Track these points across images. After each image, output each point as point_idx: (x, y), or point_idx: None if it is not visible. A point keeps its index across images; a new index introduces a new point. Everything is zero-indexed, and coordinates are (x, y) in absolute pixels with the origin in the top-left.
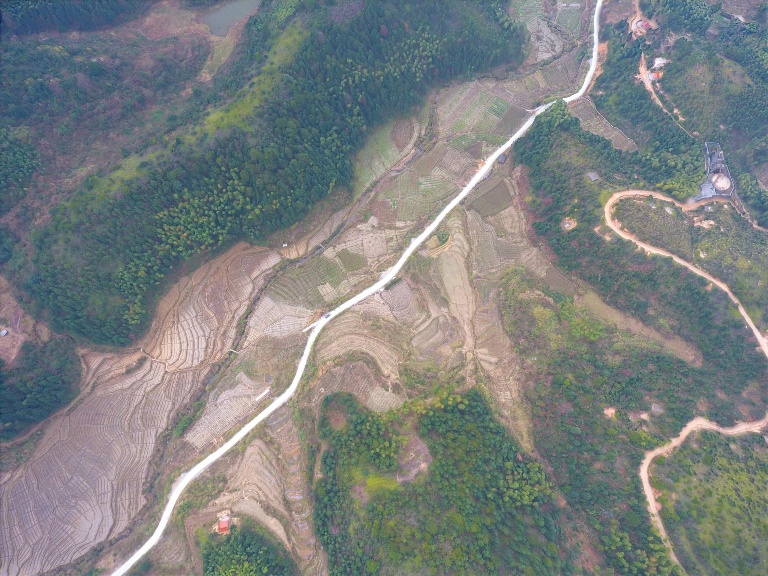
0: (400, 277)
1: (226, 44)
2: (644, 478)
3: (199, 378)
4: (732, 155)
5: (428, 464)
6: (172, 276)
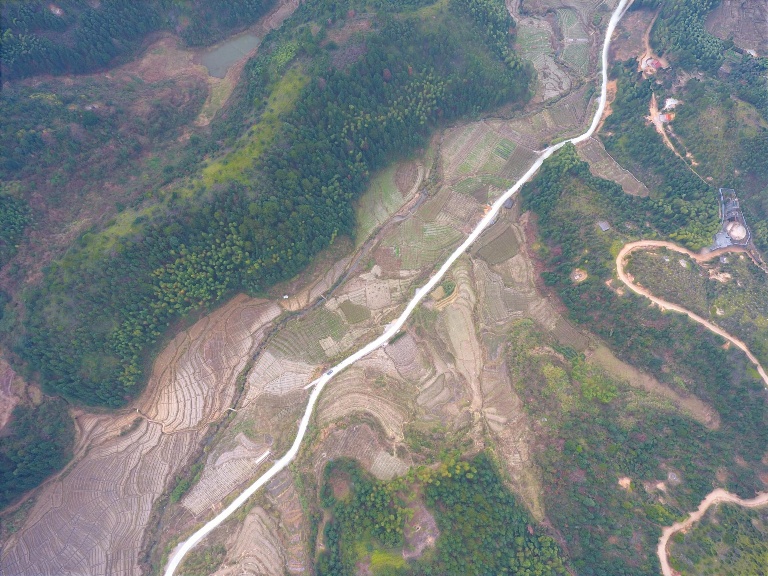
0: (404, 330)
1: (225, 86)
2: (662, 557)
3: (197, 439)
4: (747, 201)
5: (435, 539)
6: (169, 332)
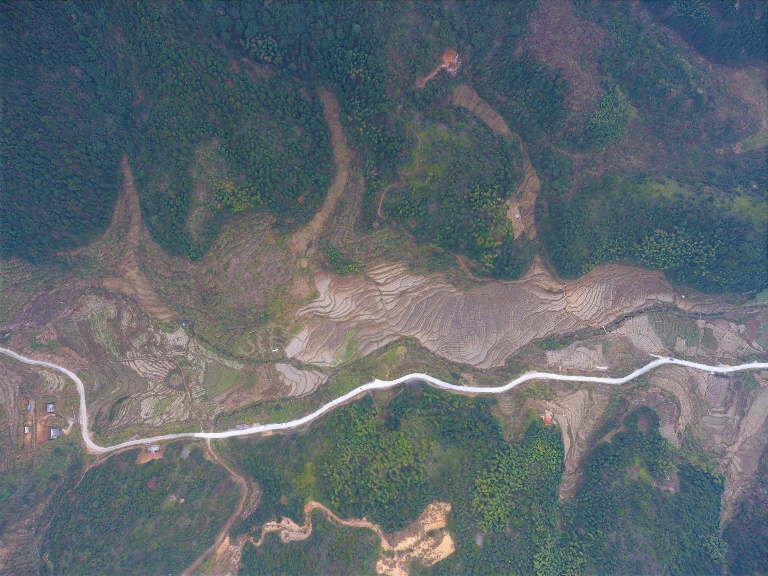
0: (729, 376)
1: None
2: None
3: (577, 327)
4: None
5: (677, 492)
6: None
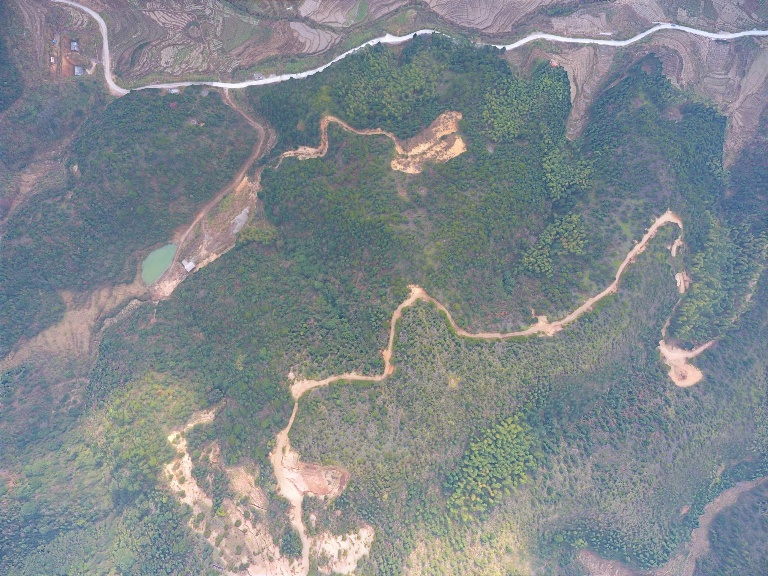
0: (729, 42)
1: None
2: None
3: None
4: None
5: None
6: None
